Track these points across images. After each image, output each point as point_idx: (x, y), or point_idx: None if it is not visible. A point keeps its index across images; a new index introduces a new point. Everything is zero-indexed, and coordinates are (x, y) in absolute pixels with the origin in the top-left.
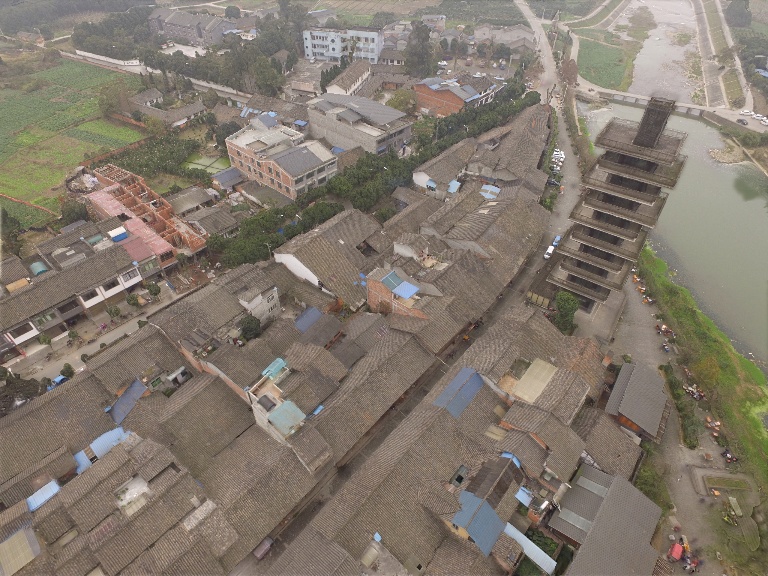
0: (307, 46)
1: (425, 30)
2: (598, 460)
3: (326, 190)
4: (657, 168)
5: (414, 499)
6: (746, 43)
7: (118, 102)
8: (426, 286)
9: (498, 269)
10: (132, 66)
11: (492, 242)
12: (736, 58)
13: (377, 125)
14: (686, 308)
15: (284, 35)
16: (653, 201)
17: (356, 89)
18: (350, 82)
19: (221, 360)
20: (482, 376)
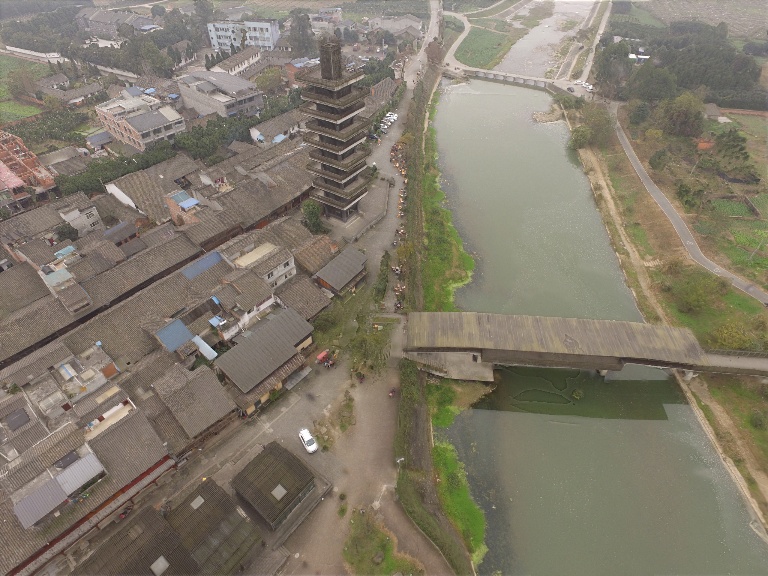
0: (212, 37)
1: (302, 18)
2: (289, 304)
3: (170, 143)
4: (345, 96)
5: (137, 325)
6: (615, 27)
7: (22, 84)
8: (214, 203)
9: (280, 192)
10: (54, 58)
11: (281, 173)
12: (598, 39)
13: (230, 94)
14: (438, 222)
15: (193, 28)
16: (337, 119)
17: (242, 71)
18: (233, 64)
19: (25, 247)
20: (221, 254)
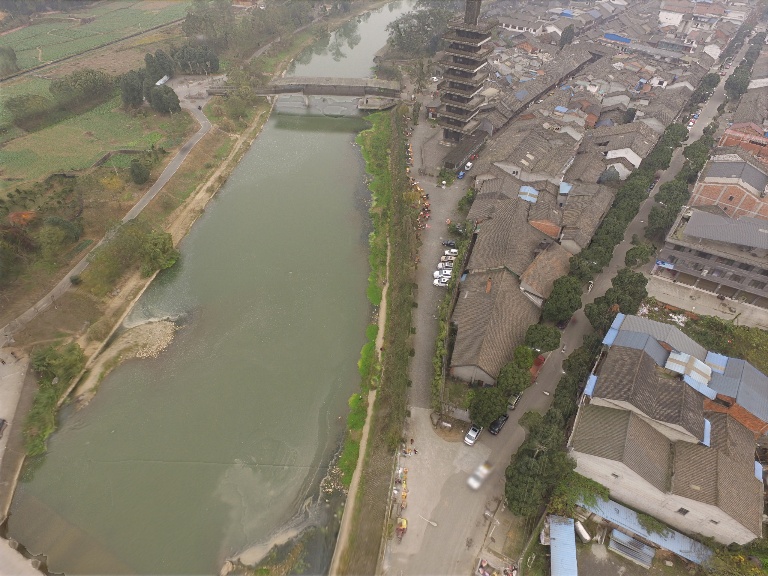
0: None
1: None
2: None
3: (678, 176)
4: None
5: None
6: None
7: None
8: None
9: None
10: None
11: None
12: None
13: None
14: None
15: None
16: None
17: None
18: None
19: None
20: None
